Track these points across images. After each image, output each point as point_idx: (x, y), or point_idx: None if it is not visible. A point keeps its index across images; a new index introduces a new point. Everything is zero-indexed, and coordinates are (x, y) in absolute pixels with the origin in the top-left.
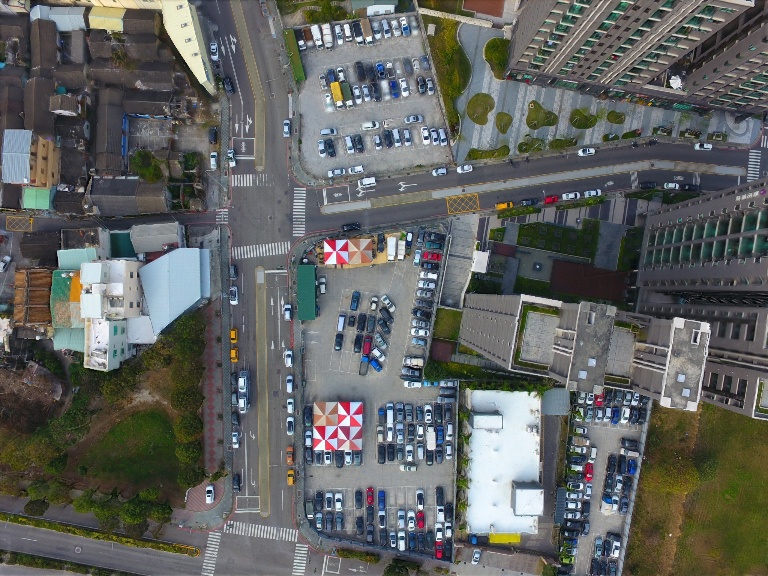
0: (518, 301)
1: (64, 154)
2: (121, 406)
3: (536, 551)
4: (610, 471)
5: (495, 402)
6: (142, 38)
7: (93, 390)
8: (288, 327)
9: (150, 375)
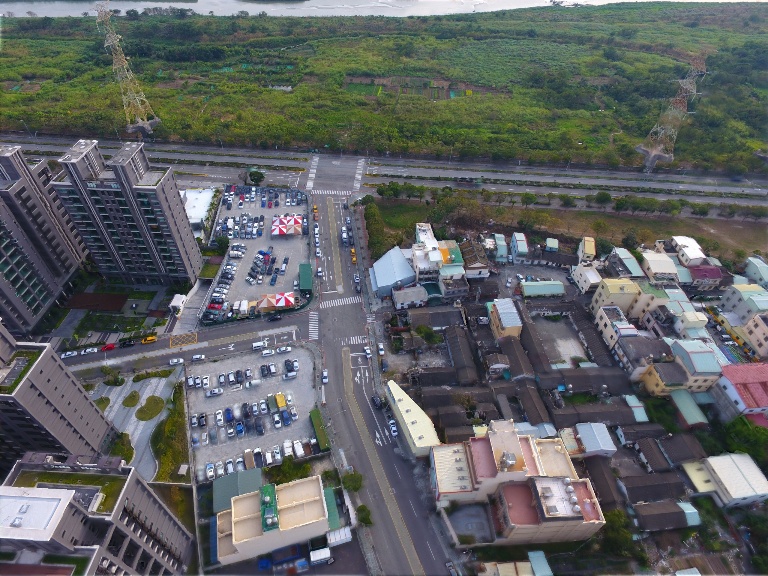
0: None
1: None
2: None
3: None
4: None
5: None
6: (453, 420)
7: None
8: None
9: (404, 242)
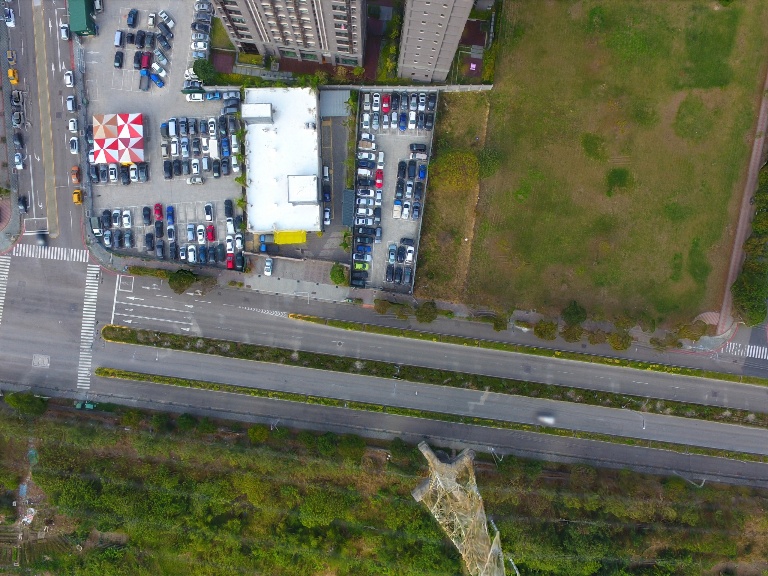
0: None
1: None
2: None
3: (329, 259)
4: (399, 175)
5: (272, 102)
6: None
7: None
8: (68, 48)
9: None
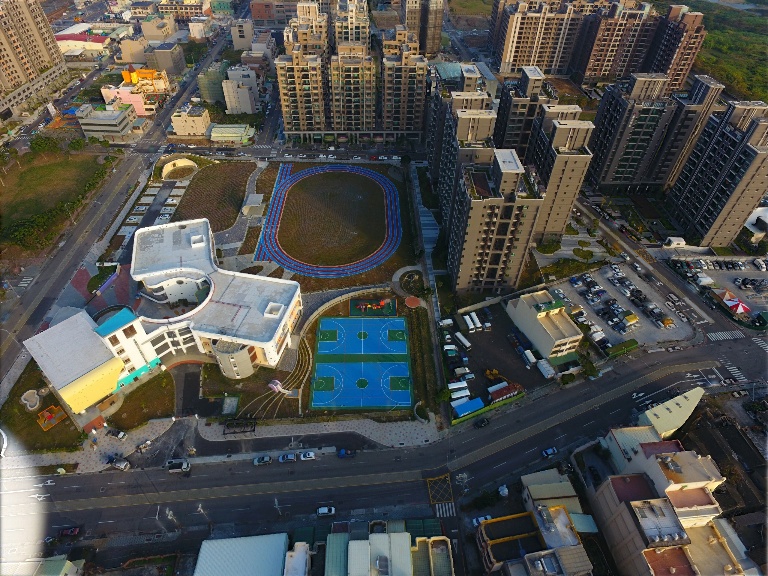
0: (761, 154)
1: None
2: None
3: None
4: None
5: (749, 226)
6: None
7: None
8: None
9: None
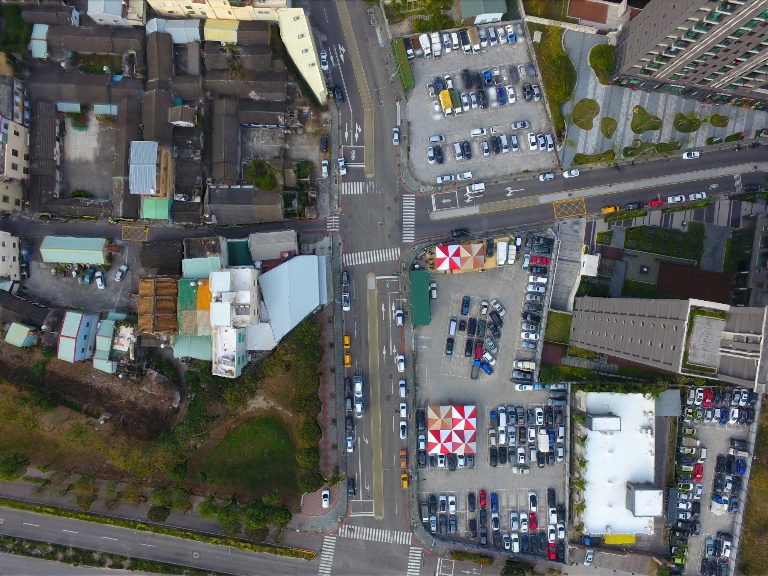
0: (686, 305)
1: (178, 164)
2: (236, 412)
3: (647, 551)
4: (720, 471)
5: (609, 404)
6: (256, 49)
7: (216, 397)
8: (399, 332)
9: (264, 381)
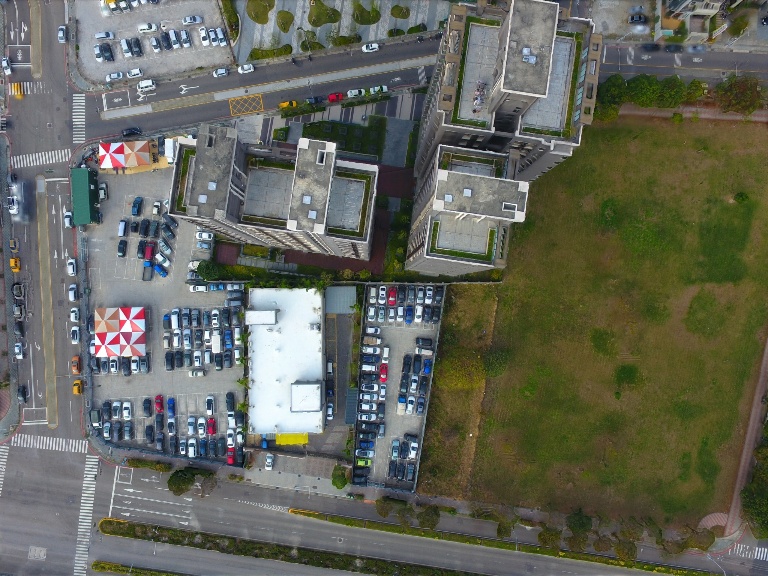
0: None
1: None
2: None
3: (331, 455)
4: (404, 371)
5: (276, 301)
6: None
7: None
8: (71, 235)
9: None
